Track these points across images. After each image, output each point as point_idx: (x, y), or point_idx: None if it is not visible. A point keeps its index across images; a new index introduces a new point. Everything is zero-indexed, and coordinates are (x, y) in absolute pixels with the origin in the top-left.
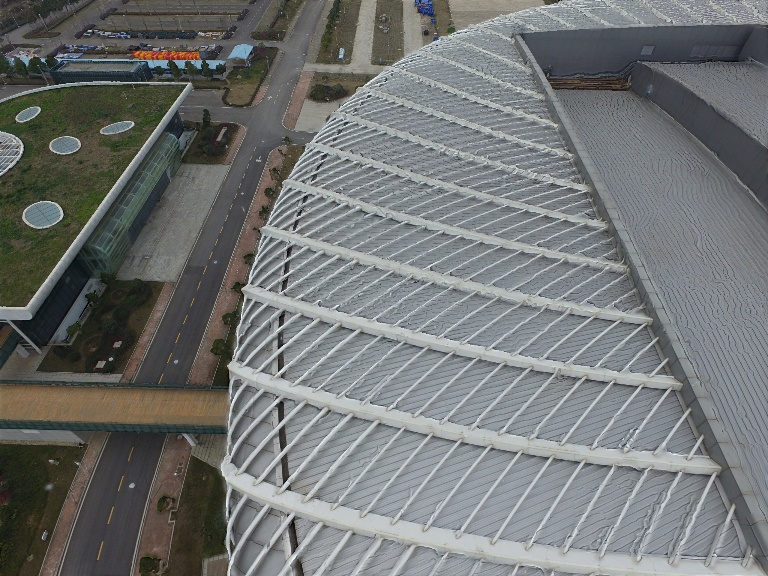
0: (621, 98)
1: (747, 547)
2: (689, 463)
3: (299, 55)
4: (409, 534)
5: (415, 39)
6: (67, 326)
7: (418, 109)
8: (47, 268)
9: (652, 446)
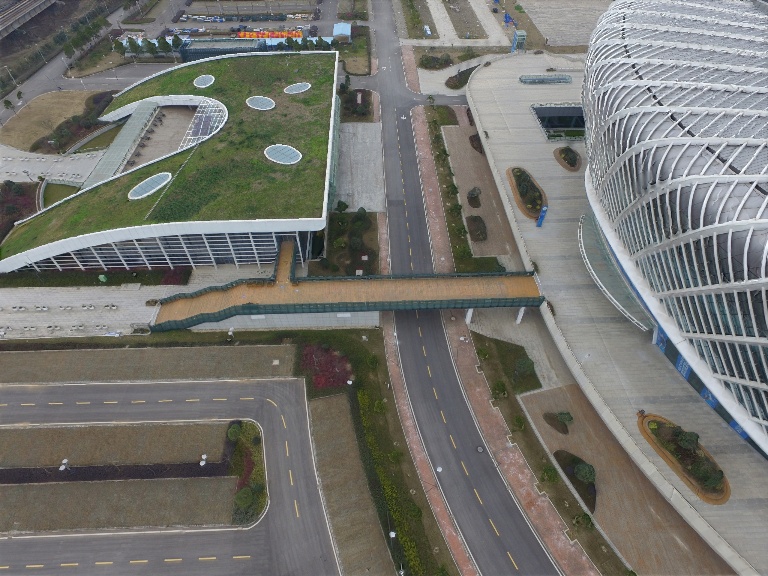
0: None
1: None
2: None
3: (390, 32)
4: None
5: (488, 16)
6: None
7: (687, 31)
8: (317, 191)
9: None
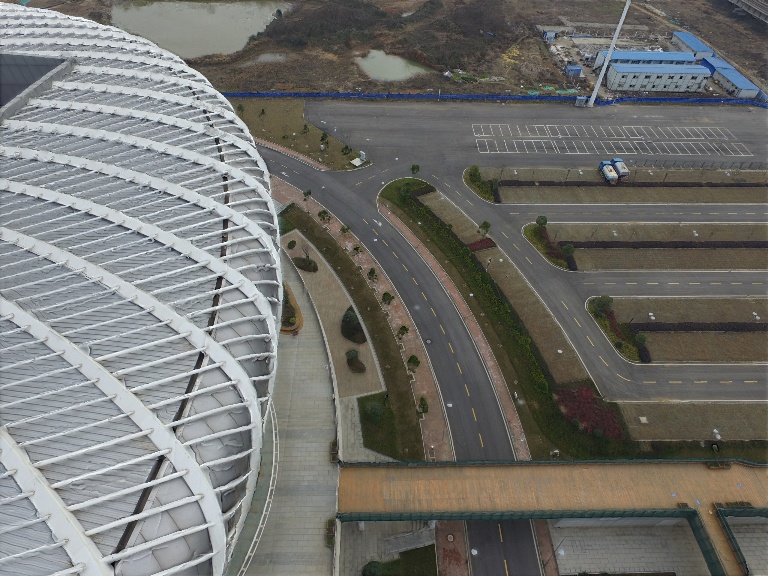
0: None
1: (0, 127)
2: None
3: None
4: (159, 143)
5: None
6: None
7: None
8: None
9: (0, 157)
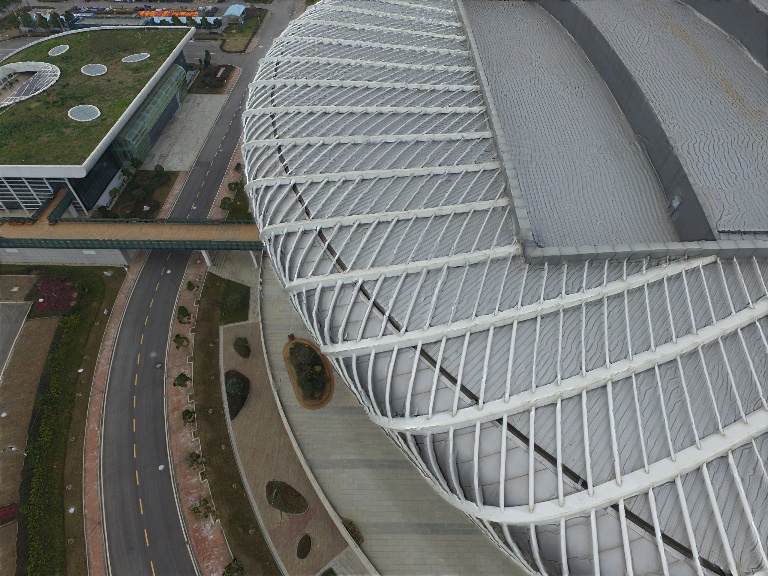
0: (515, 2)
1: None
2: (473, 108)
3: (286, 15)
4: None
5: None
6: (105, 201)
7: None
8: (93, 144)
9: None
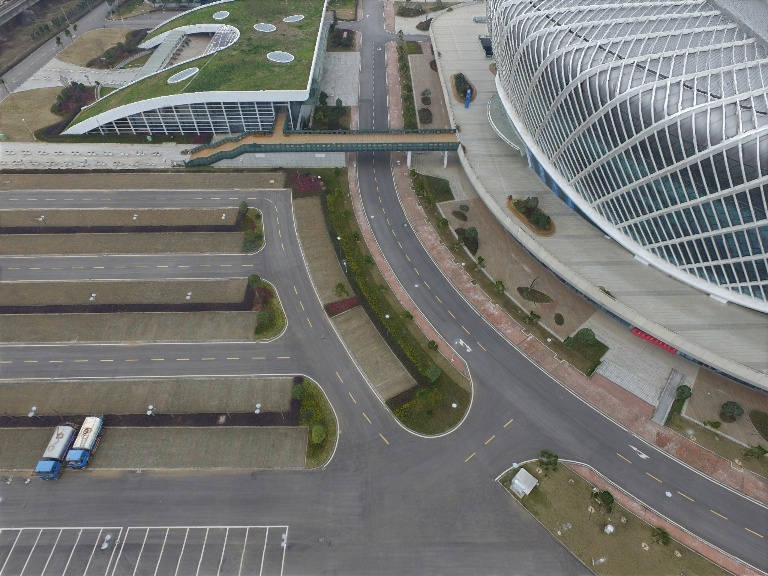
0: None
1: None
2: (697, 1)
3: None
4: None
5: None
6: None
7: None
8: (304, 77)
9: None
